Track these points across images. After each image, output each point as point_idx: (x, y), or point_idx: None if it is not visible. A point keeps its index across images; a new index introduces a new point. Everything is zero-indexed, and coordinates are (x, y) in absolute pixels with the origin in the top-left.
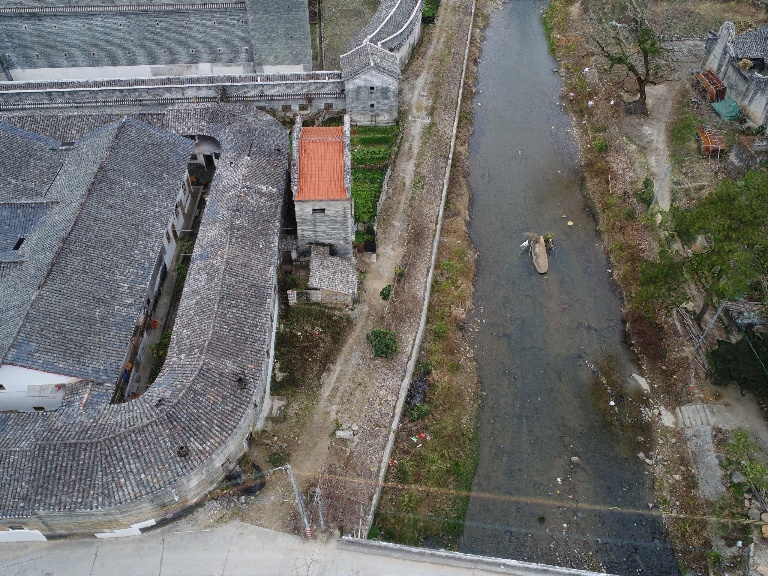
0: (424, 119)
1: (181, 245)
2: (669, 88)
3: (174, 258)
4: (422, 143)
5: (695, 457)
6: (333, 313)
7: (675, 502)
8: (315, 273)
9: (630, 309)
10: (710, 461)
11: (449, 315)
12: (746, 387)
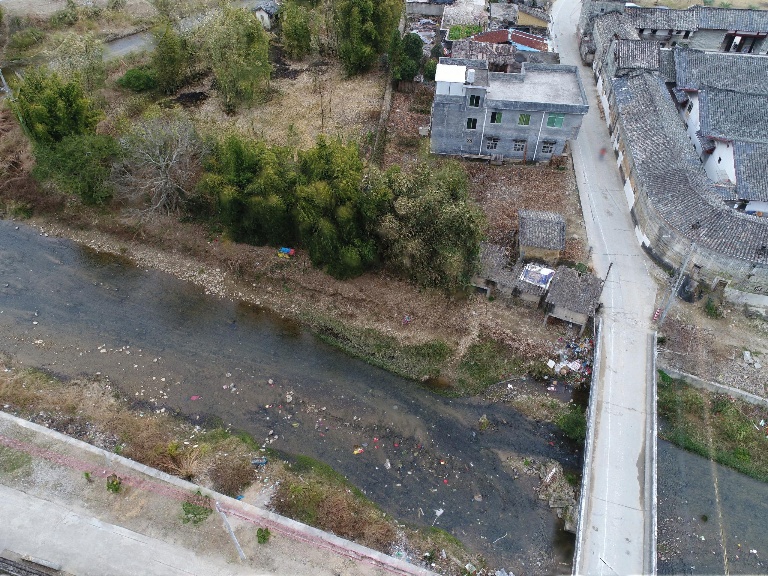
0: None
1: None
2: None
3: None
4: None
5: None
6: None
7: None
8: None
9: None
10: None
11: None
12: None
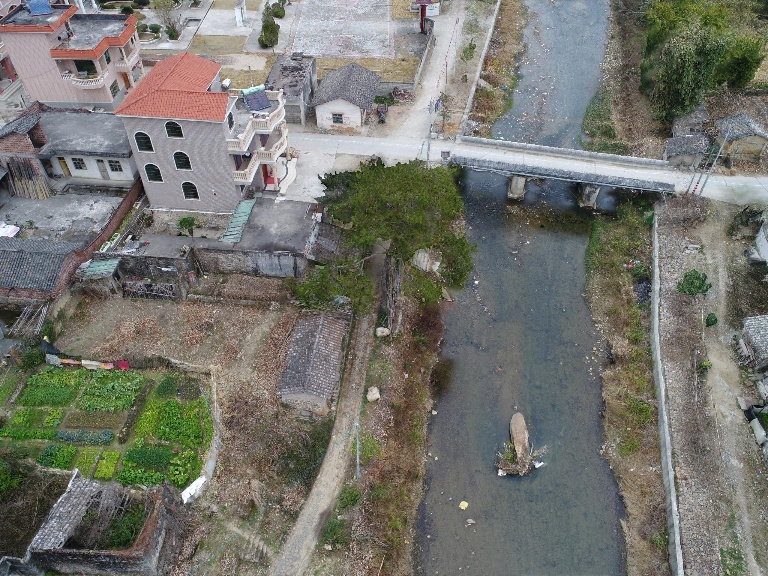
0: None
1: None
2: None
3: None
4: None
5: None
6: None
7: None
8: None
9: None
10: None
11: None
12: None
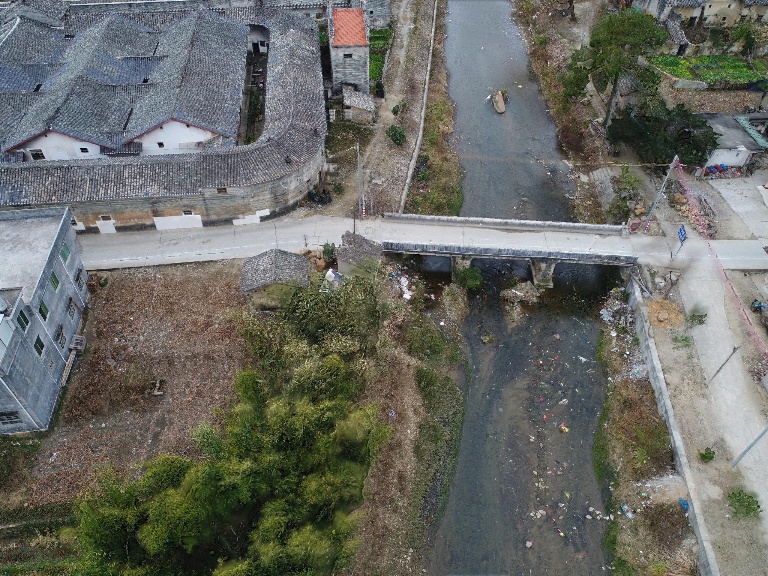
0: (410, 25)
1: (246, 96)
2: (592, 4)
3: (243, 103)
4: (410, 39)
5: (600, 193)
6: (360, 126)
7: (587, 214)
8: (347, 98)
9: (561, 126)
10: (609, 192)
11: (438, 132)
12: (628, 142)
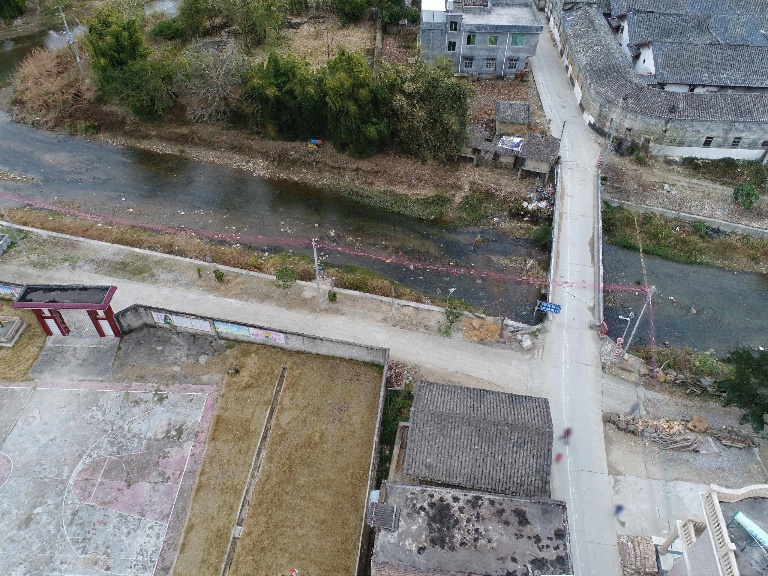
0: None
1: None
2: None
3: None
4: None
5: None
6: (767, 183)
7: None
8: None
9: None
10: None
11: None
12: None
